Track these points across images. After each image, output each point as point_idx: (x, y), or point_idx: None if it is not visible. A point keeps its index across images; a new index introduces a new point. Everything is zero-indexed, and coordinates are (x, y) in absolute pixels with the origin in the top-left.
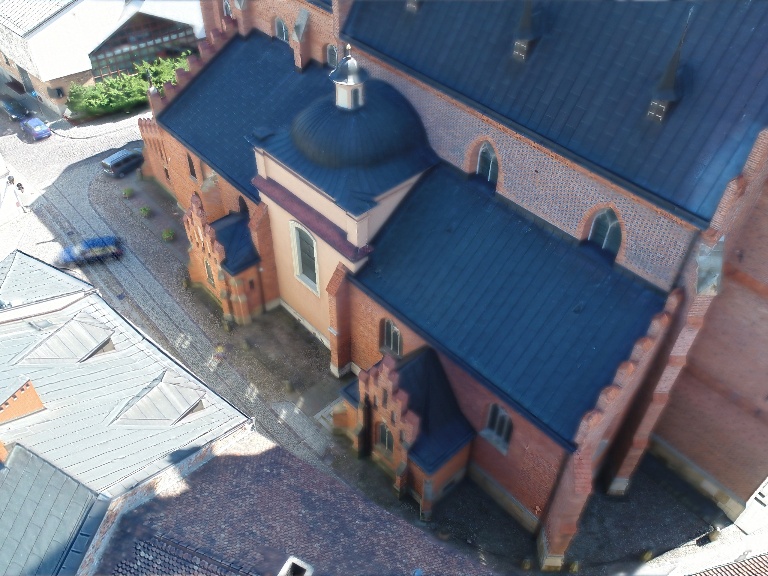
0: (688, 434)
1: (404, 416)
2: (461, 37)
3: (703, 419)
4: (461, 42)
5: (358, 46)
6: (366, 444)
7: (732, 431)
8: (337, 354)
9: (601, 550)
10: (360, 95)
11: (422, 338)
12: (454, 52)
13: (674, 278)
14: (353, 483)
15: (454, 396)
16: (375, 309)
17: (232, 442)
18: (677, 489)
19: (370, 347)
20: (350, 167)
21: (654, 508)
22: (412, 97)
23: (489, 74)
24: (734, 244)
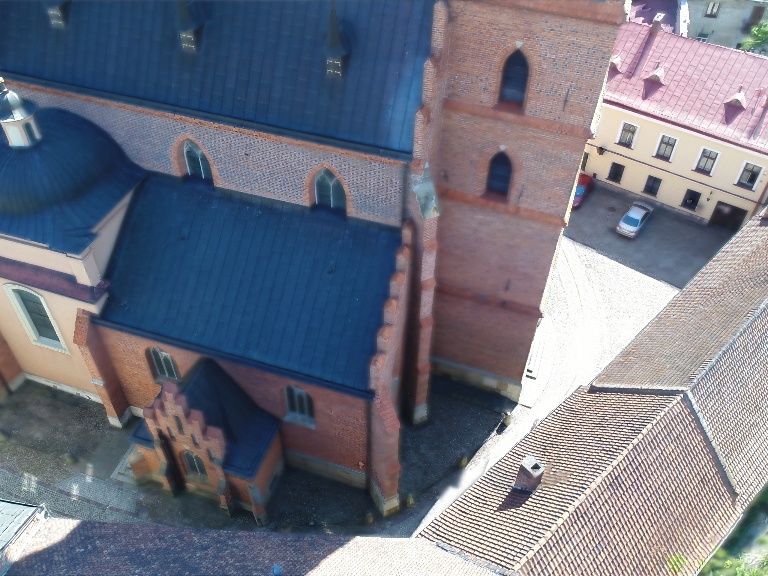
0: (459, 345)
1: (205, 434)
2: (123, 43)
3: (466, 327)
4: (125, 48)
5: (12, 78)
6: (177, 479)
7: (491, 328)
8: (111, 404)
9: (426, 475)
10: (34, 128)
11: (195, 352)
12: (121, 59)
13: (401, 213)
14: (178, 523)
15: (247, 395)
16: (135, 343)
17: (28, 540)
18: (467, 395)
19: (144, 383)
20: (52, 207)
21: (455, 419)
22: (93, 116)
23: (166, 73)
24: (437, 168)
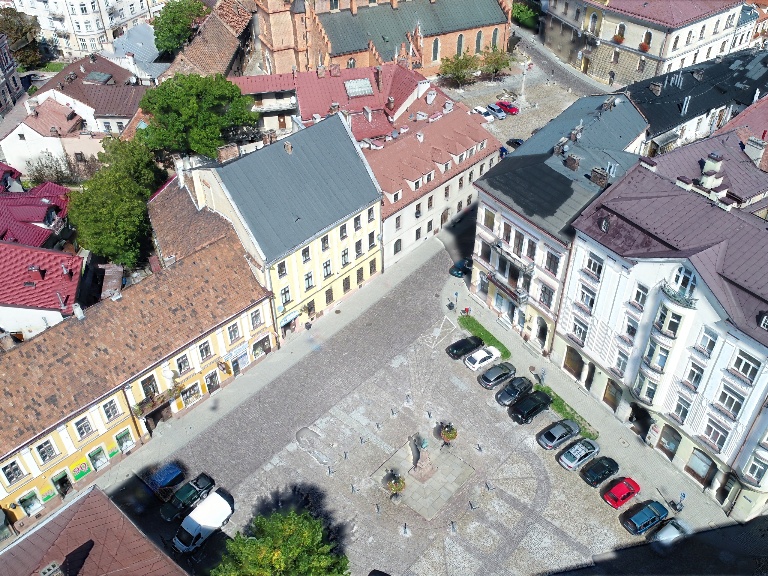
0: None
1: None
2: None
3: None
4: None
5: None
6: None
7: None
8: None
9: None
10: None
11: None
12: None
13: None
14: None
15: None
16: None
17: None
18: None
19: None
20: None
21: None
22: None
23: None
24: None
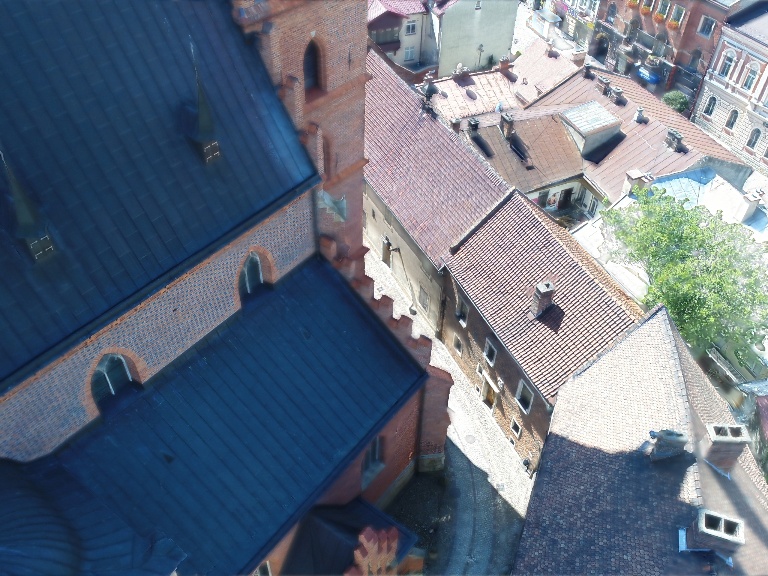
0: None
1: None
2: None
3: None
4: None
5: None
6: None
7: None
8: None
9: None
10: None
11: None
12: None
13: (314, 238)
14: None
15: None
16: None
17: None
18: None
19: None
20: (80, 571)
21: None
22: None
23: (36, 306)
24: None
